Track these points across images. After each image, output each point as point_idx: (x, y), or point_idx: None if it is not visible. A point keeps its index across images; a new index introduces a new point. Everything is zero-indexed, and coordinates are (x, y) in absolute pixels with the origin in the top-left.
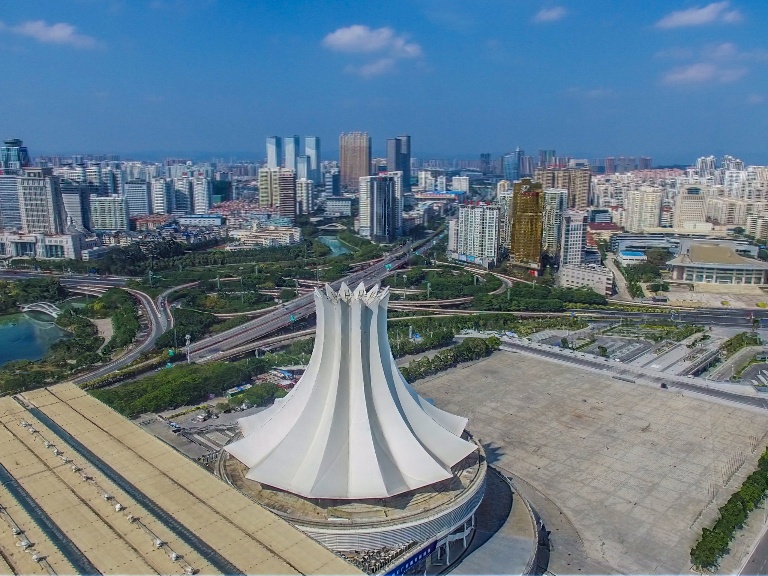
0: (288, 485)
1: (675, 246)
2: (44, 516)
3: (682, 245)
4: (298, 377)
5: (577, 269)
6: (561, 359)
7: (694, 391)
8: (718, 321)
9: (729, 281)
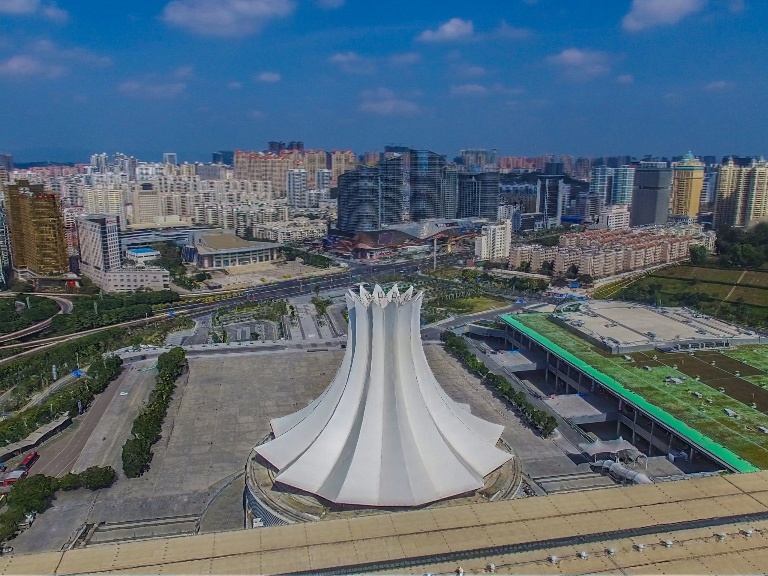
0: (437, 494)
1: (182, 238)
2: None
3: (194, 236)
4: (8, 465)
5: (126, 272)
6: (241, 352)
7: None
8: None
9: (248, 262)
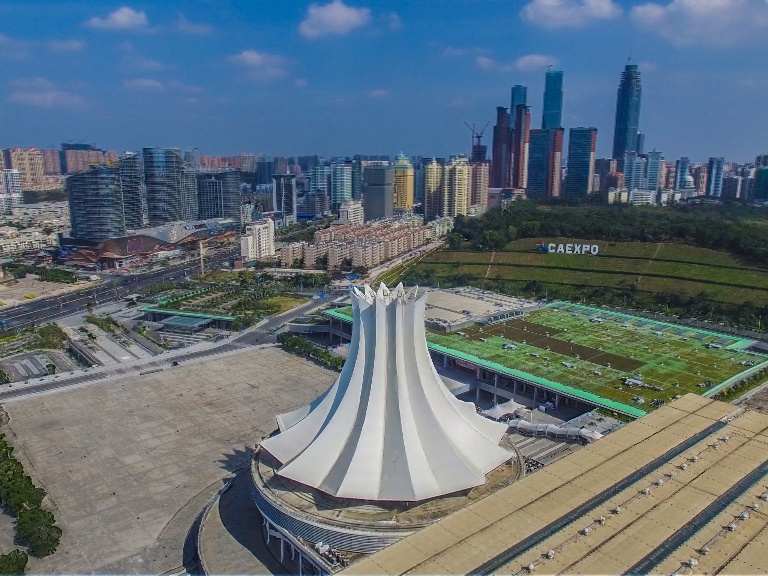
0: None
1: None
2: (635, 570)
3: None
4: None
5: None
6: (51, 388)
7: (192, 359)
8: (36, 318)
9: None
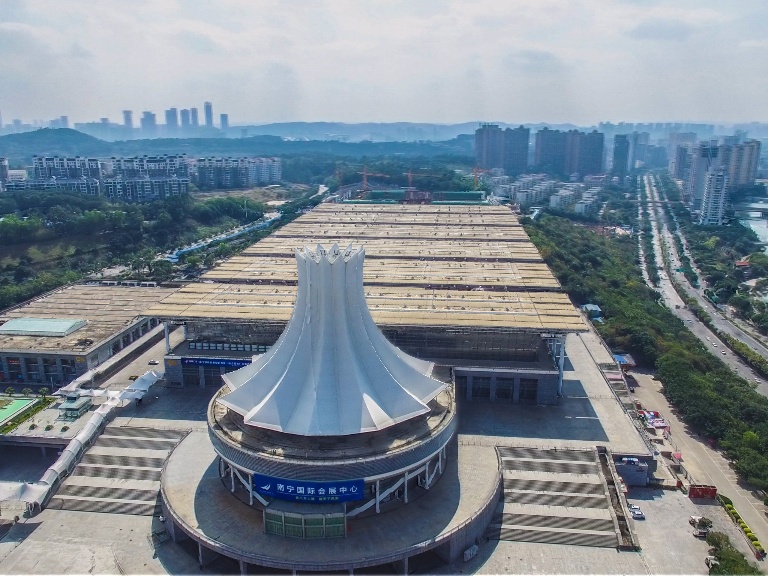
0: None
1: None
2: None
3: None
4: None
5: None
6: None
7: None
8: None
9: None
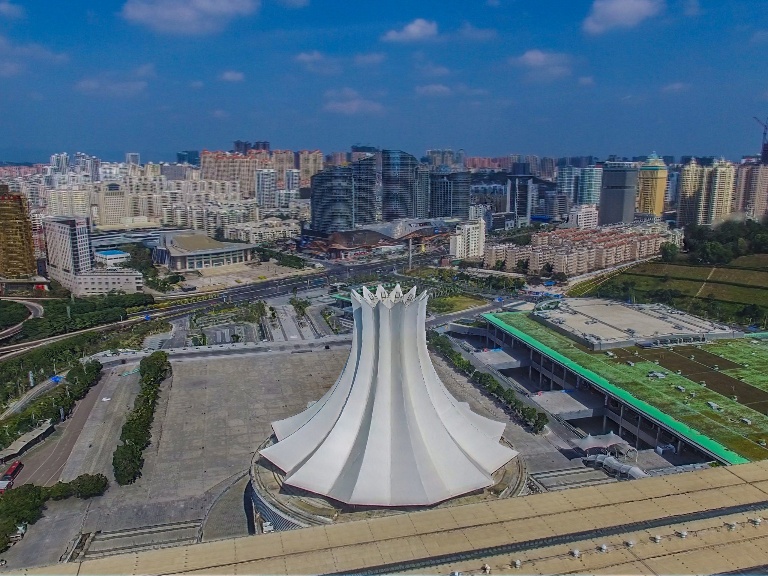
0: (448, 493)
1: (153, 240)
2: None
3: (166, 237)
4: None
5: (97, 274)
6: (223, 354)
7: (345, 345)
8: (256, 295)
9: (222, 263)
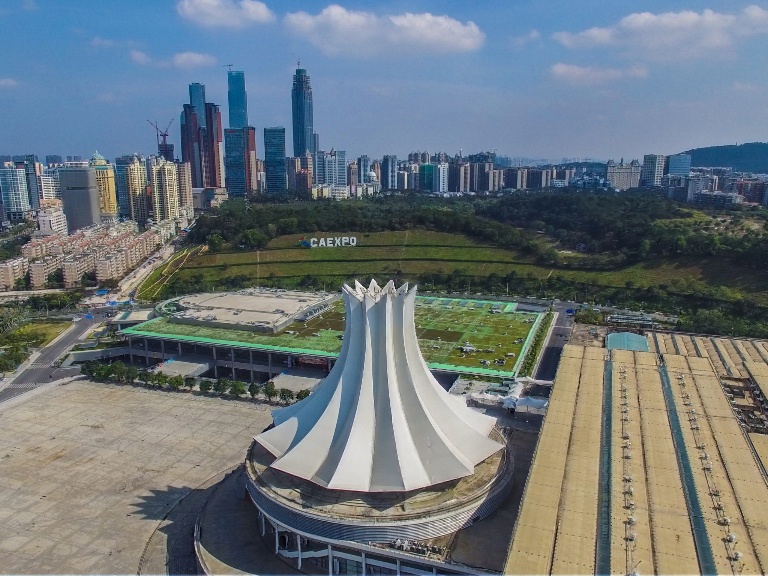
0: None
1: None
2: None
3: None
4: None
5: None
6: None
7: None
8: None
9: None
